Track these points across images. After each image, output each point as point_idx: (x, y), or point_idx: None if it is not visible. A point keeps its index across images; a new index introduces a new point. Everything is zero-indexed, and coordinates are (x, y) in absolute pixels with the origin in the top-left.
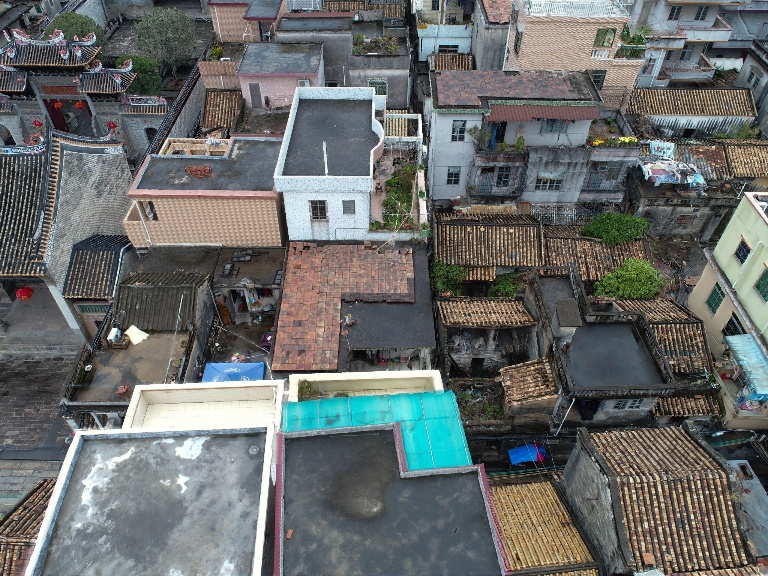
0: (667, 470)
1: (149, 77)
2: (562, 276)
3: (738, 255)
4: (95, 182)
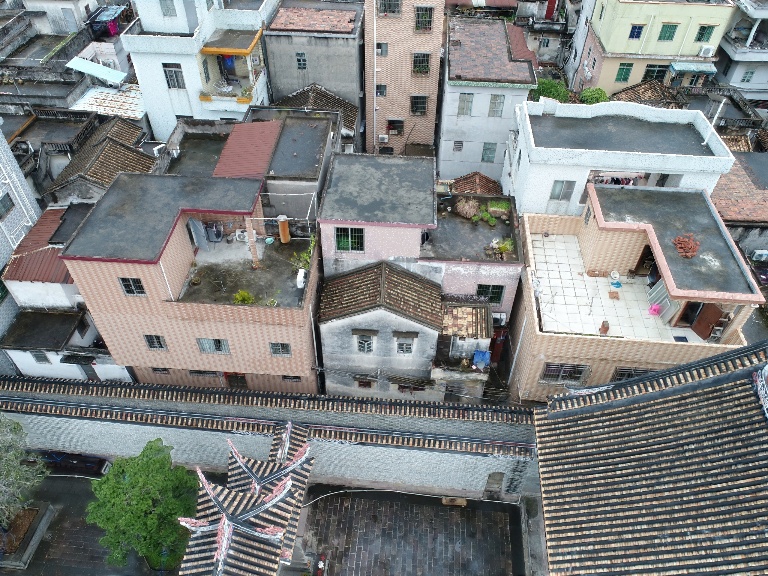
0: None
1: (181, 467)
2: None
3: (633, 36)
4: None
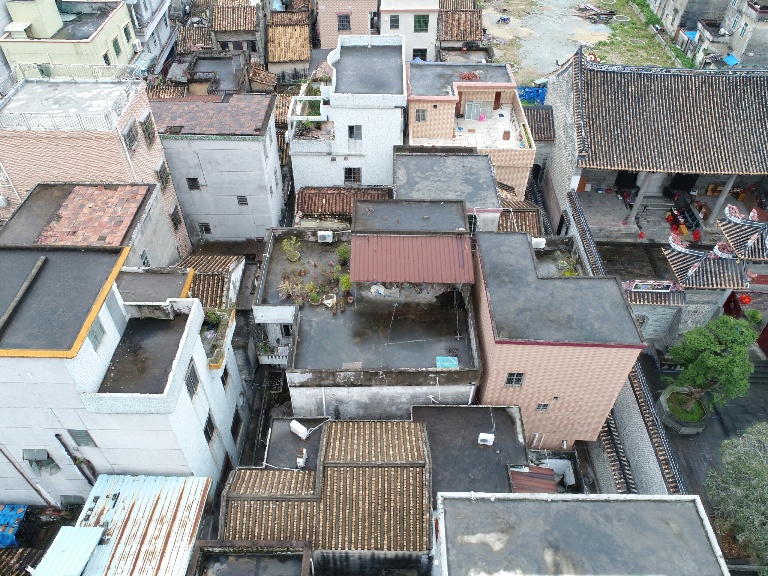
0: (235, 8)
1: None
2: None
3: None
4: None
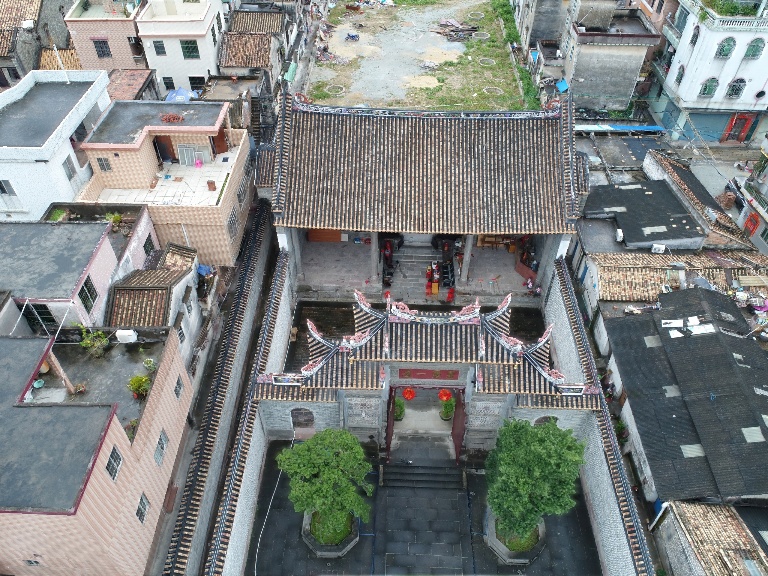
0: None
1: None
2: None
3: None
4: None
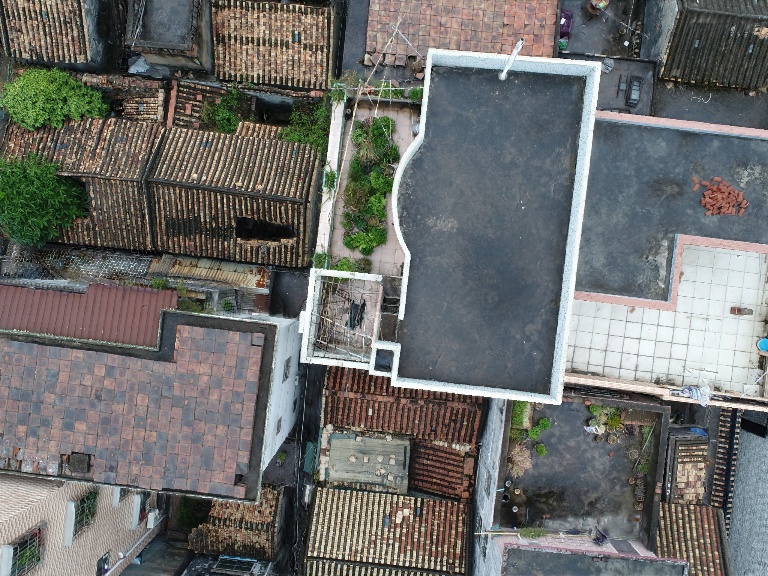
0: None
1: None
2: None
3: None
4: None
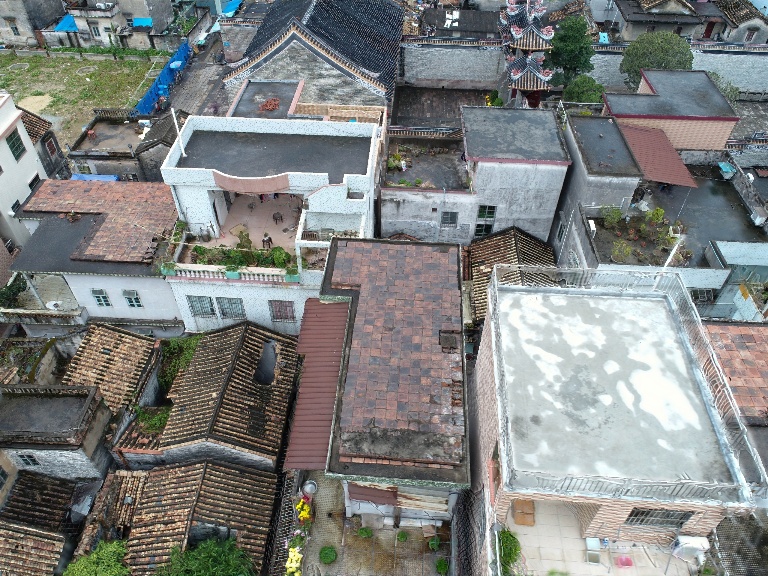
0: None
1: None
2: (82, 431)
3: None
4: (323, 86)
